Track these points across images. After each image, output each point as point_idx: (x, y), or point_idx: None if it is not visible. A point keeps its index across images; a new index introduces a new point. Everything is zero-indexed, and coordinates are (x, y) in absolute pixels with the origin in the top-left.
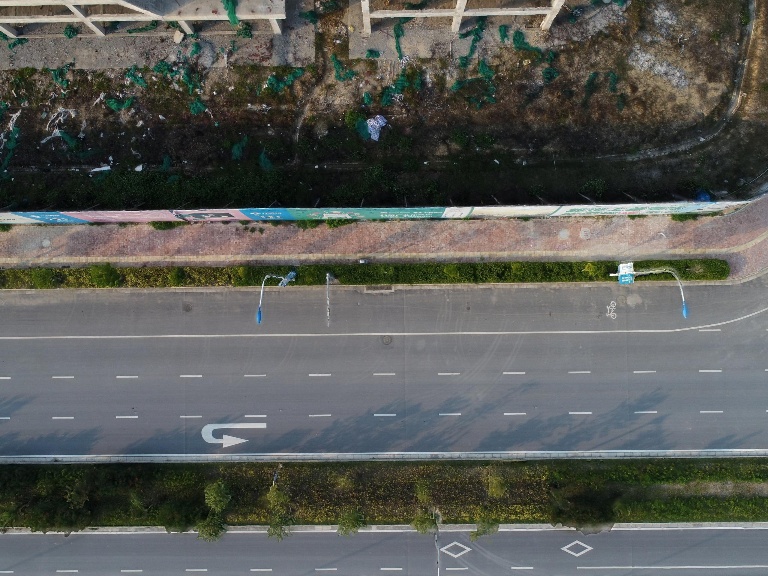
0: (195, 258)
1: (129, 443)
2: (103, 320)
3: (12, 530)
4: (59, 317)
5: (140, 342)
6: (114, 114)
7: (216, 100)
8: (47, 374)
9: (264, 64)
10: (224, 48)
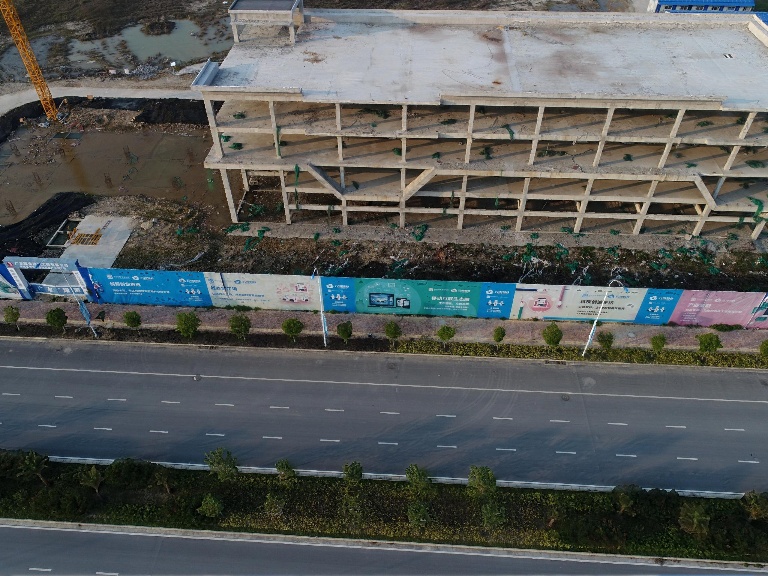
0: (756, 350)
1: (761, 484)
2: (695, 387)
3: (670, 562)
4: (656, 383)
5: (734, 405)
6: (656, 271)
7: (725, 268)
8: (660, 423)
9: (753, 252)
10: (721, 244)
